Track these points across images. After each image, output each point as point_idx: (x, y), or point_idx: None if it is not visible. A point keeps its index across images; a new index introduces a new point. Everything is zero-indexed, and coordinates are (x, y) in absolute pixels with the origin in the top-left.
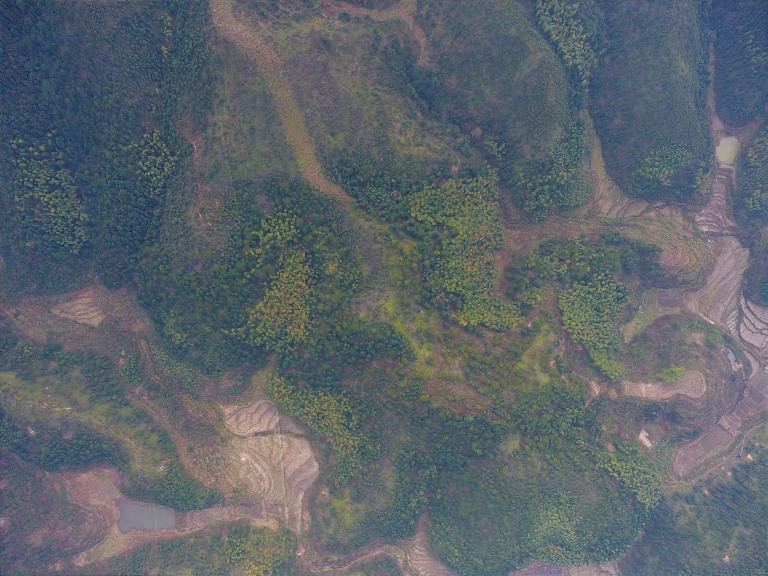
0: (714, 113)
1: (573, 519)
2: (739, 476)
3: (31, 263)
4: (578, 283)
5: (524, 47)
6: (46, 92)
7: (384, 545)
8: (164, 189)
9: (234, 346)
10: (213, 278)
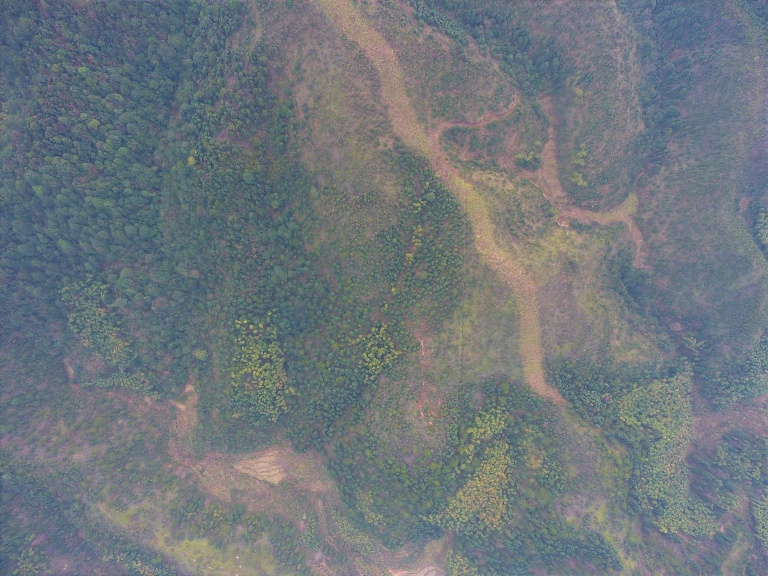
0: None
1: None
2: None
3: (229, 428)
4: None
5: (749, 265)
6: (276, 276)
7: None
8: (379, 376)
9: (425, 527)
10: (425, 473)
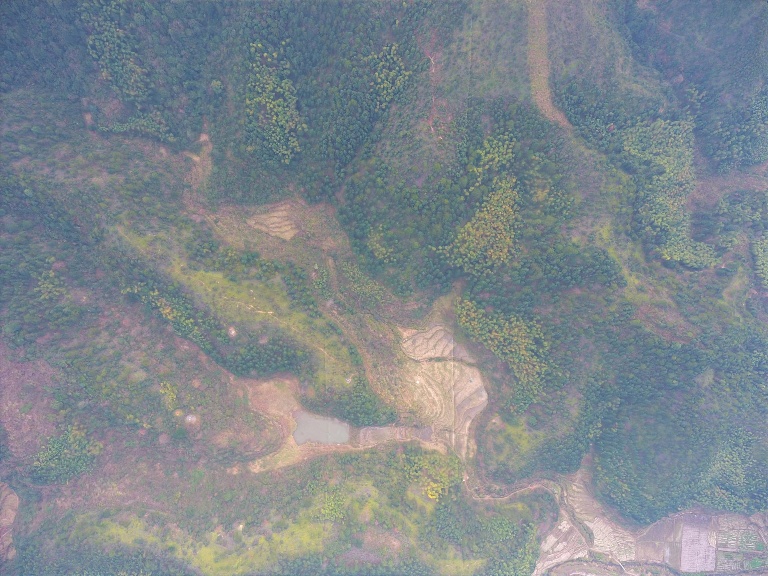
0: None
1: (747, 461)
2: None
3: (244, 169)
4: None
5: None
6: None
7: (542, 480)
8: (390, 104)
9: (434, 265)
10: (435, 192)
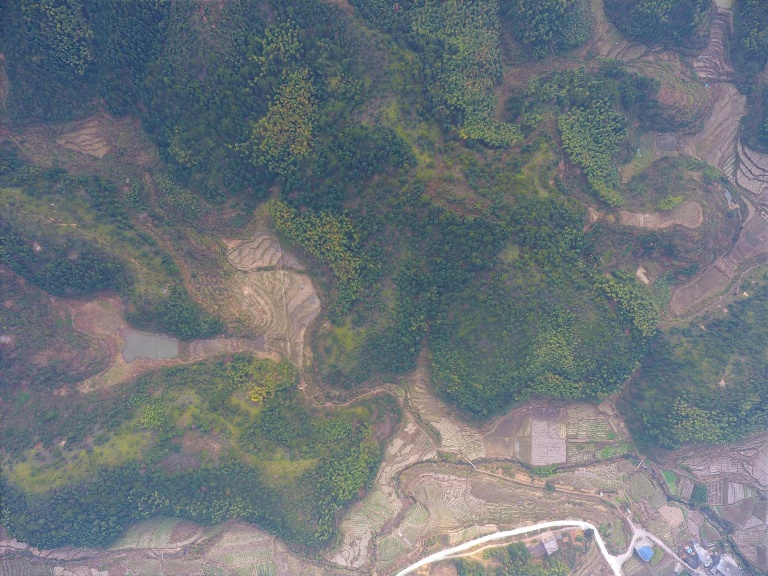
0: None
1: (571, 342)
2: (735, 311)
3: (37, 83)
4: (577, 108)
5: None
6: None
7: (385, 384)
8: None
9: (237, 166)
10: (217, 84)
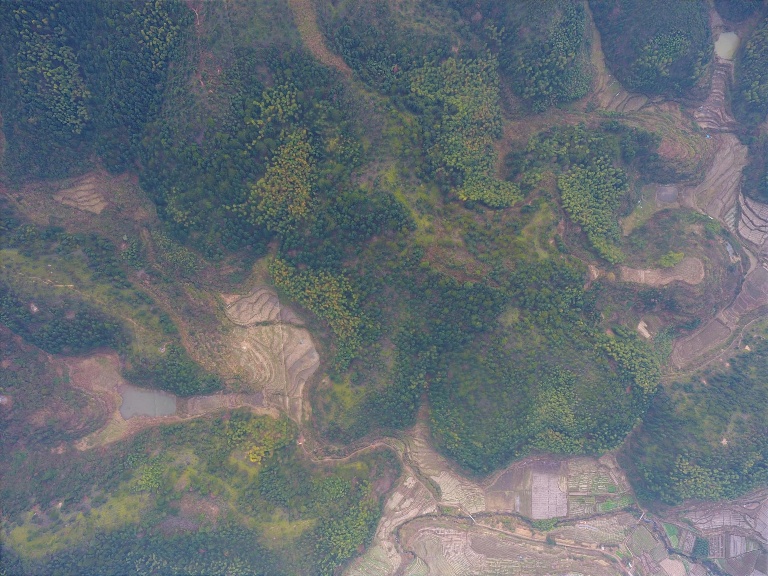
0: (713, 8)
1: (572, 401)
2: (737, 365)
3: (34, 143)
4: (577, 165)
5: None
6: None
7: (384, 437)
8: (166, 62)
9: (235, 225)
10: (215, 148)
